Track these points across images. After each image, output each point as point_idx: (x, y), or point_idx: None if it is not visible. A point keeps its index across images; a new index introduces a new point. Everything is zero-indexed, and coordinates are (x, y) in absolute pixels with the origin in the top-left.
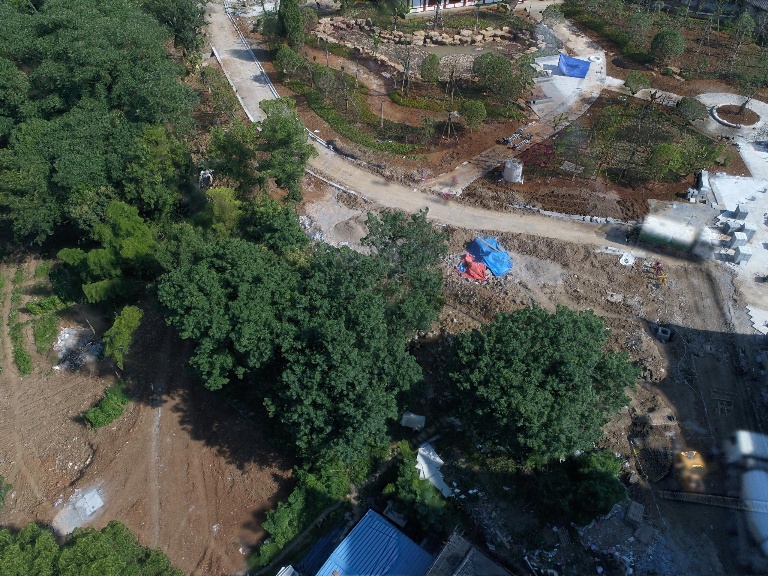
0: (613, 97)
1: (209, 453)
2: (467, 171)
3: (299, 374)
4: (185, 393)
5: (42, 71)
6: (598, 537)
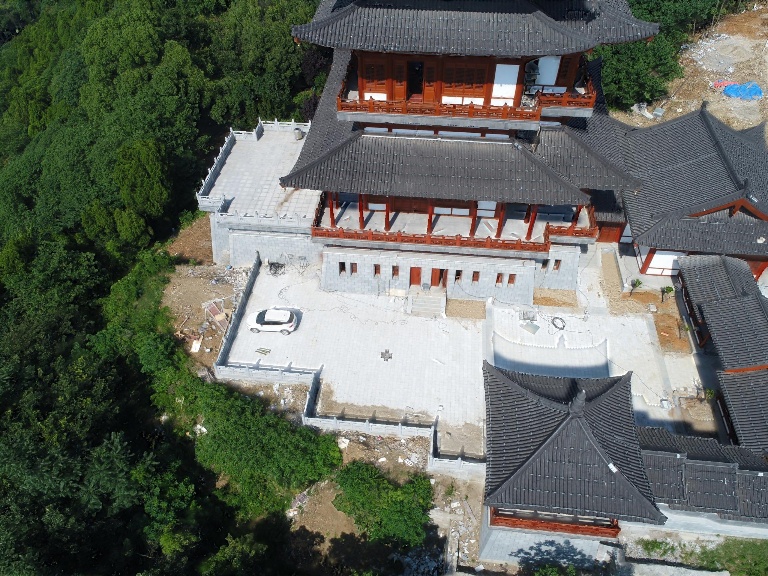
0: None
1: None
2: None
3: None
4: None
5: None
6: None
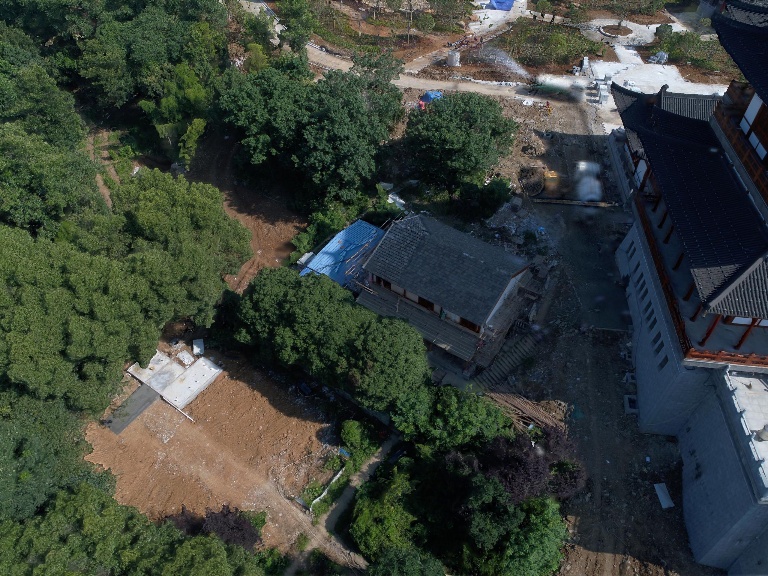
0: (530, 21)
1: (251, 219)
2: (422, 61)
3: (314, 135)
4: (230, 192)
5: None
6: (496, 221)
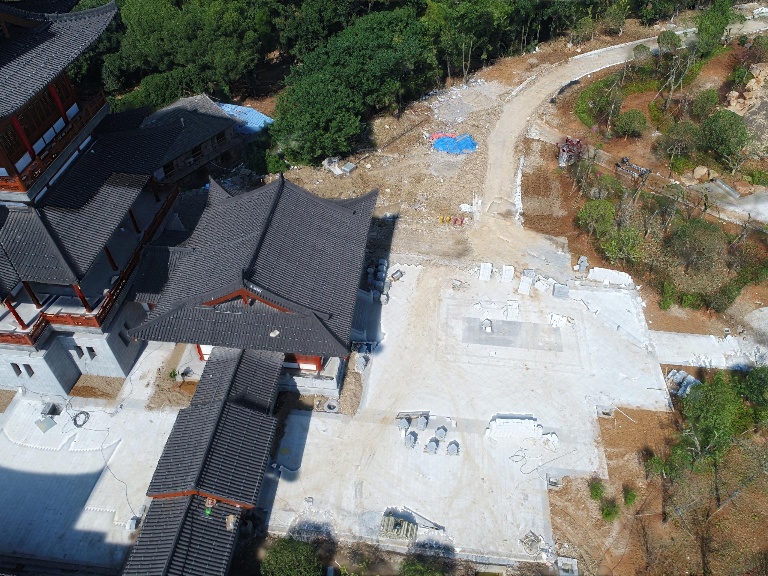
0: None
1: None
2: None
3: None
4: None
5: None
6: None
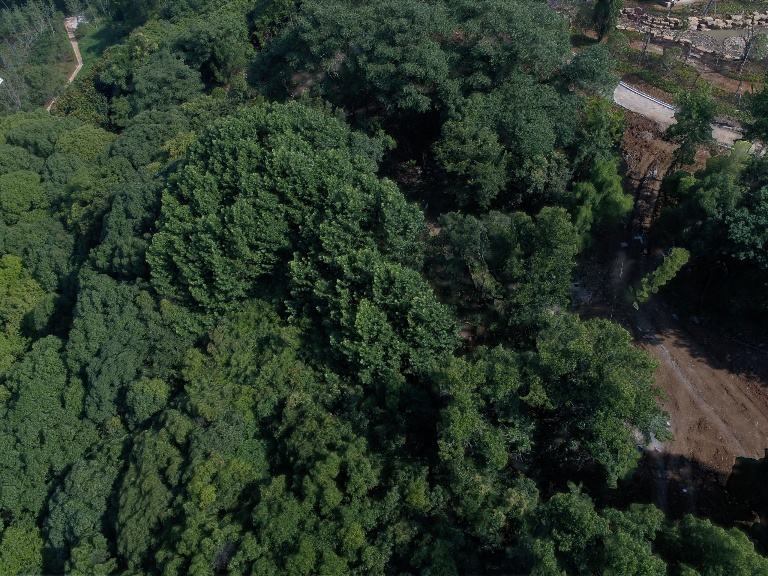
0: None
1: (739, 379)
2: None
3: None
4: (677, 332)
5: (483, 50)
6: None
